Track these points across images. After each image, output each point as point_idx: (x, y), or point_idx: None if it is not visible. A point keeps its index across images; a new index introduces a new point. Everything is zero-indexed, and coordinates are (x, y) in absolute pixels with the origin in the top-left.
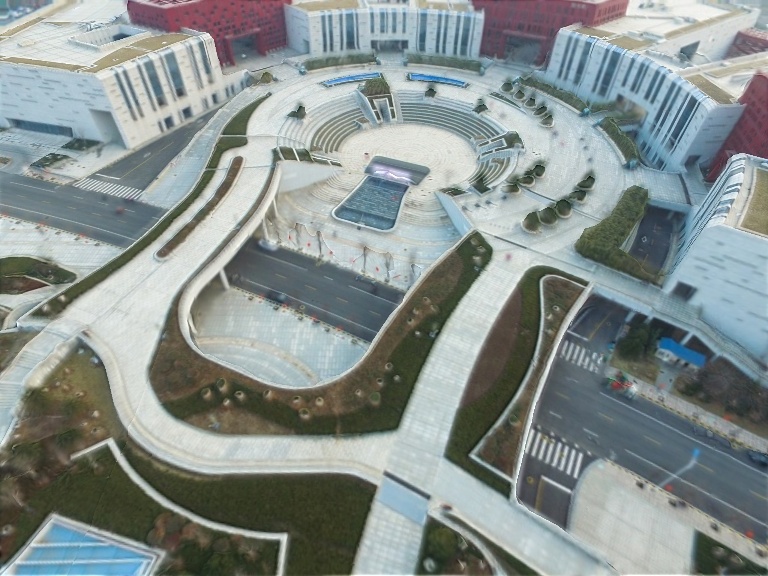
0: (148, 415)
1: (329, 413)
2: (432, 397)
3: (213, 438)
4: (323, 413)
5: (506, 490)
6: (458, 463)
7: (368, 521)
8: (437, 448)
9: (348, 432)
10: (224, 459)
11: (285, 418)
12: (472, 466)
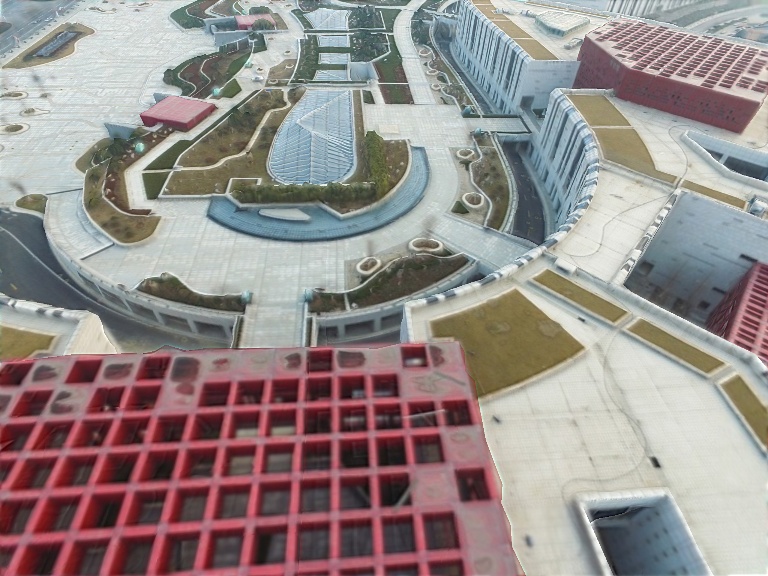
0: (335, 1)
1: (386, 3)
2: (416, 2)
3: (355, 4)
4: (385, 3)
5: (436, 10)
6: (424, 8)
7: (401, 12)
8: (418, 7)
9: (392, 5)
10: (360, 6)
11: (374, 3)
12: (427, 8)
